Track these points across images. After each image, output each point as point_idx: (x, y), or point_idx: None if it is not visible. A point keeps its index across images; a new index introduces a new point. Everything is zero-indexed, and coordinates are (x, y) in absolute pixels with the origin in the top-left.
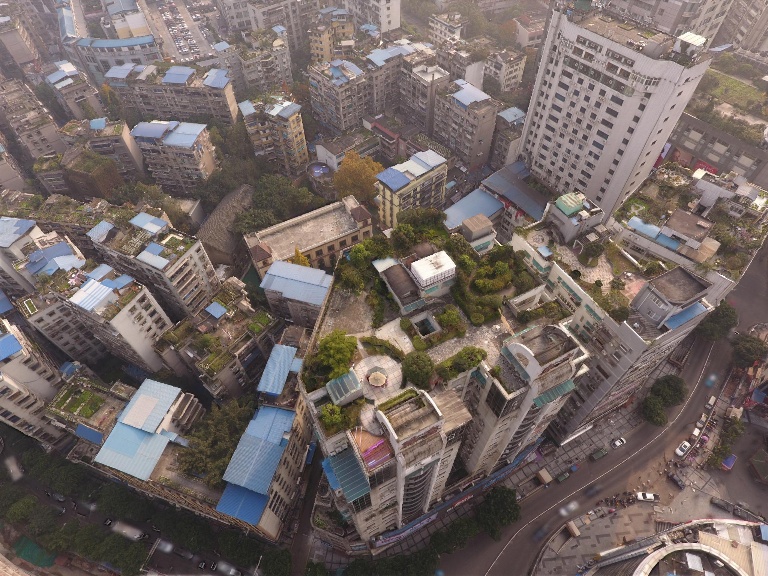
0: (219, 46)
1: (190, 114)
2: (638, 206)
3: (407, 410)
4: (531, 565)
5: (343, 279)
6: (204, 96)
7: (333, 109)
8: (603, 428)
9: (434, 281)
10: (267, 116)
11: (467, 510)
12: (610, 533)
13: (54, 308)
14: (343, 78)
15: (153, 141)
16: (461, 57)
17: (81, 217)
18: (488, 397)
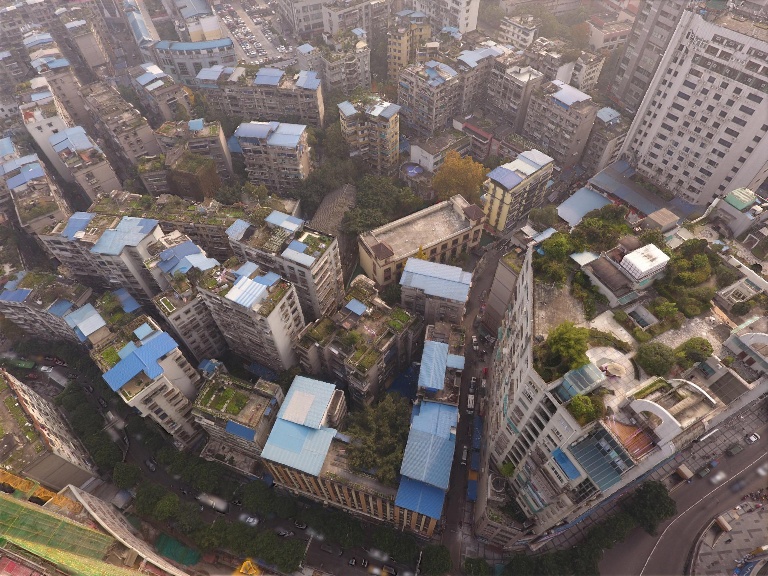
0: (303, 48)
1: (277, 115)
2: None
3: (661, 399)
4: (686, 560)
5: (551, 272)
6: (295, 97)
7: (425, 110)
8: (734, 424)
9: (647, 273)
10: (367, 116)
11: (613, 506)
12: (761, 528)
13: (190, 306)
14: (439, 79)
15: (257, 141)
16: (552, 58)
17: (193, 217)
18: (710, 388)
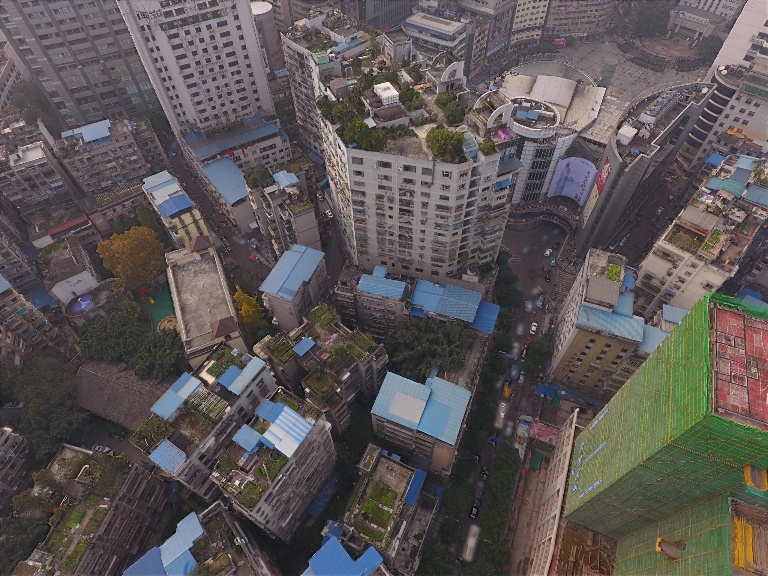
0: None
1: None
2: (315, 50)
3: (484, 115)
4: None
5: None
6: None
7: None
8: None
9: None
10: None
11: None
12: None
13: None
14: None
15: None
16: (21, 128)
17: None
18: None
